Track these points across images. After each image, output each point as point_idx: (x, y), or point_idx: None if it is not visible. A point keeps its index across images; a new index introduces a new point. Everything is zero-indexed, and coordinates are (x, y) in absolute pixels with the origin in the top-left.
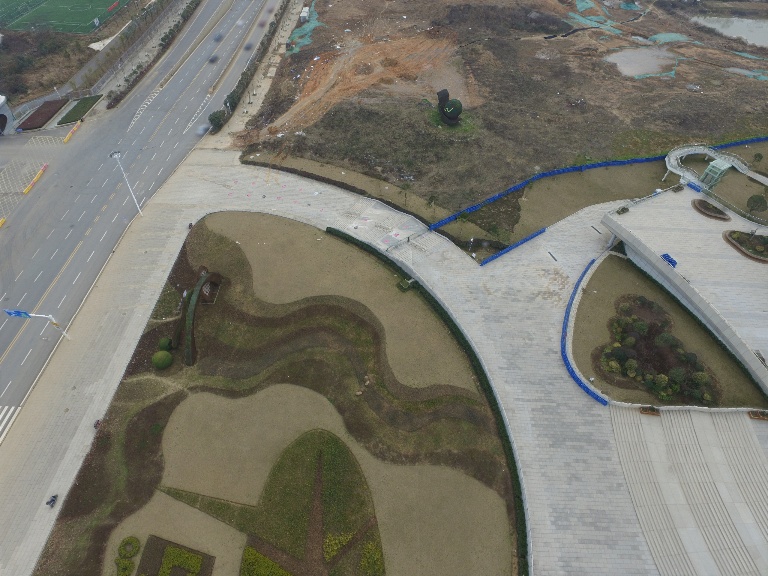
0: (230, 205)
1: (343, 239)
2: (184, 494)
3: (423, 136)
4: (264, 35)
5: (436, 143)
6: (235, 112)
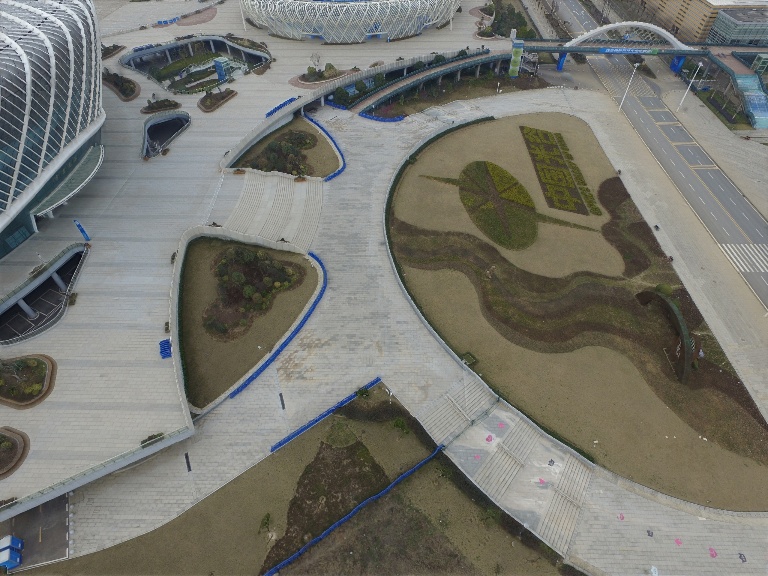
0: None
1: None
2: (583, 228)
3: None
4: None
5: None
6: None
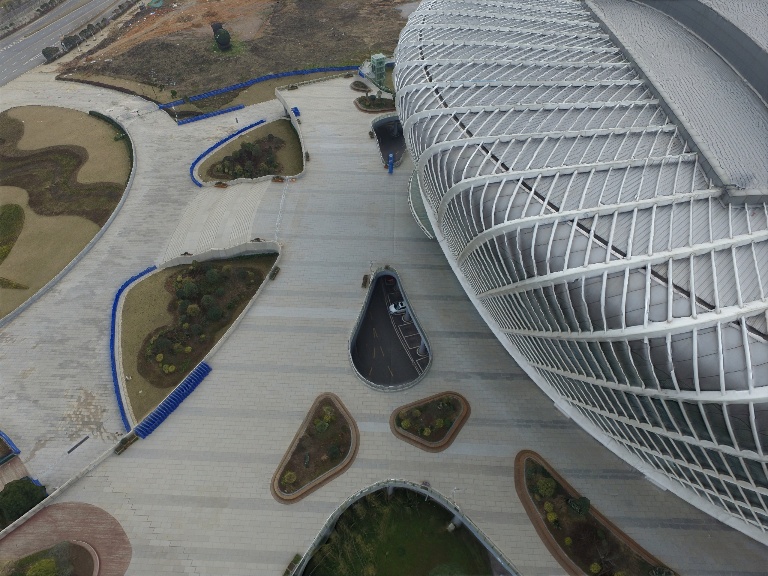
0: (31, 102)
1: (97, 117)
2: None
3: (198, 57)
4: (126, 1)
5: (204, 61)
6: (72, 51)
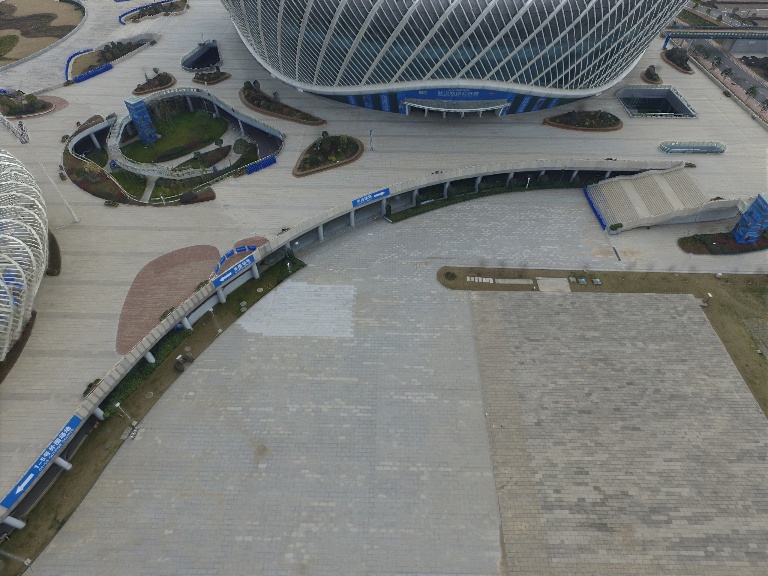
0: None
1: (65, 2)
2: None
3: None
4: None
5: None
6: None
